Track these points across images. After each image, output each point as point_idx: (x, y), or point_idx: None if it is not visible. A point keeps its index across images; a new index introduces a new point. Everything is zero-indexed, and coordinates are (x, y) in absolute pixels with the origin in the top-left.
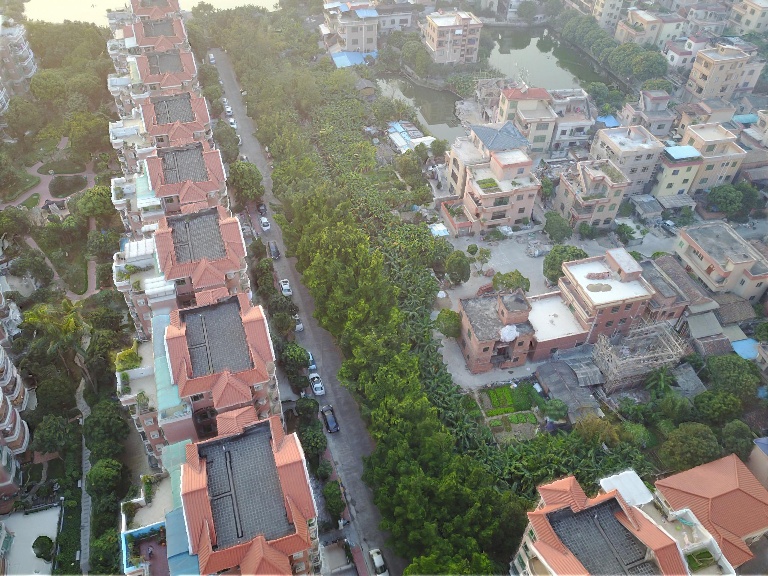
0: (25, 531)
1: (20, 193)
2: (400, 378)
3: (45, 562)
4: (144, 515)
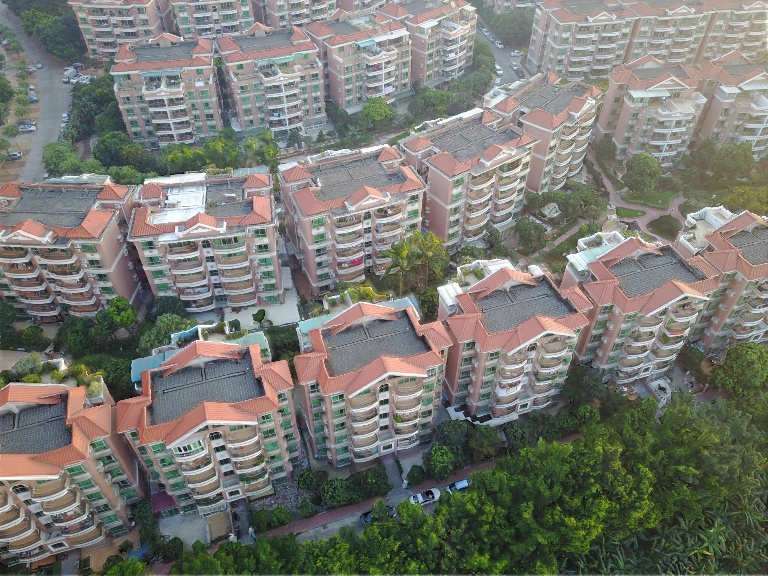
0: (285, 308)
1: (639, 203)
2: (391, 573)
3: (260, 325)
4: (217, 338)
